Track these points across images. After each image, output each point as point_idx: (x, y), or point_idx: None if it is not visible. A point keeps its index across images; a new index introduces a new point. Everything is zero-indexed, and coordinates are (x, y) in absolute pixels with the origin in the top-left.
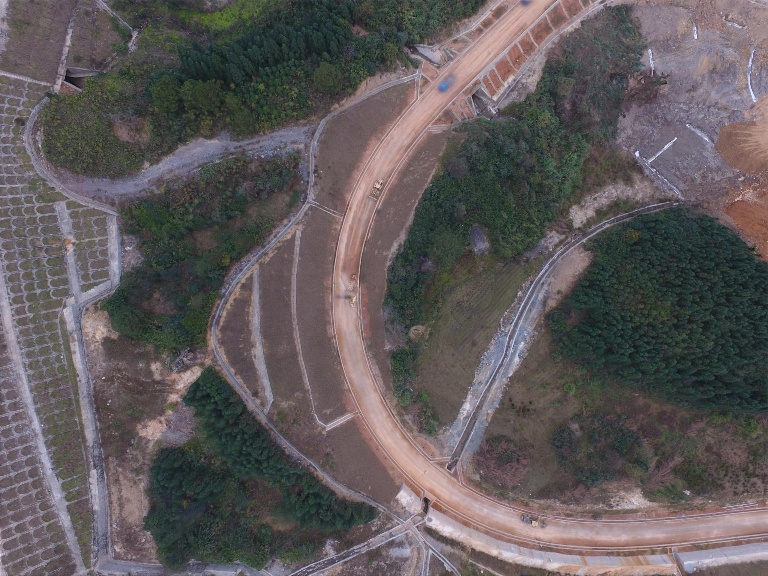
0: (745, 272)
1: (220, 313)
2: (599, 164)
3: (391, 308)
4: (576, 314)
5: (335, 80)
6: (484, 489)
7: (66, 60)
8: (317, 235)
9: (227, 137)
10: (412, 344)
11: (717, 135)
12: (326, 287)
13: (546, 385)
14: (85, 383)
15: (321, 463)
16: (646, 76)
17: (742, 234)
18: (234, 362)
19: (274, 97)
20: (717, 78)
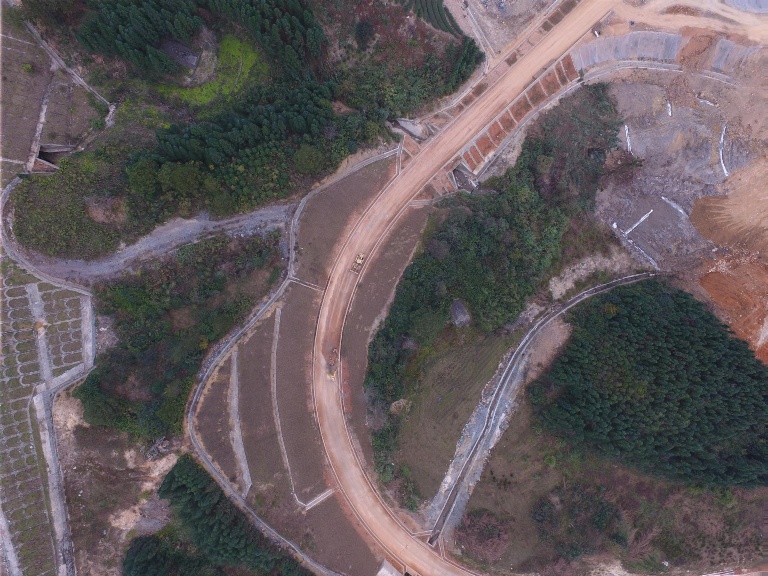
0: (719, 351)
1: (197, 399)
2: (578, 236)
3: (372, 387)
4: (556, 390)
5: (316, 163)
6: (466, 563)
7: (40, 137)
8: (297, 311)
9: (206, 217)
10: (393, 420)
11: (691, 208)
12: (307, 361)
13: (527, 458)
14: (55, 473)
15: (301, 545)
16: (622, 158)
17: (716, 308)
18: (211, 448)
19: (254, 178)
20: (691, 154)
